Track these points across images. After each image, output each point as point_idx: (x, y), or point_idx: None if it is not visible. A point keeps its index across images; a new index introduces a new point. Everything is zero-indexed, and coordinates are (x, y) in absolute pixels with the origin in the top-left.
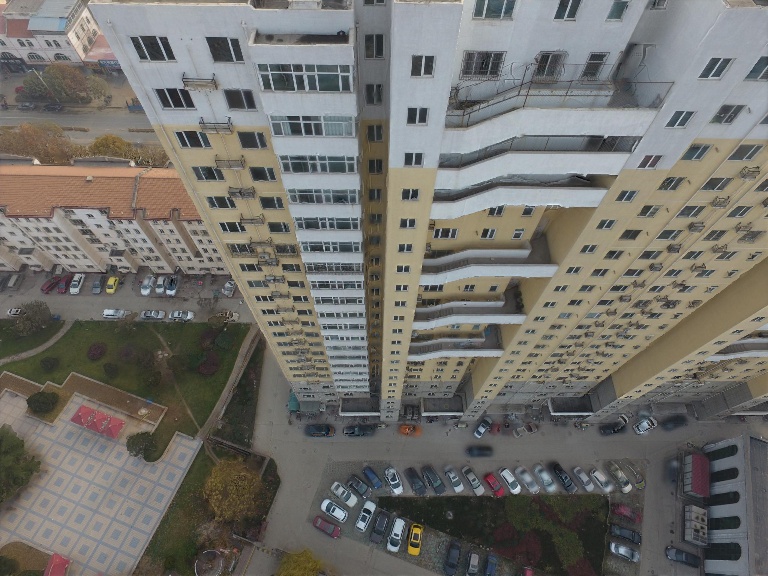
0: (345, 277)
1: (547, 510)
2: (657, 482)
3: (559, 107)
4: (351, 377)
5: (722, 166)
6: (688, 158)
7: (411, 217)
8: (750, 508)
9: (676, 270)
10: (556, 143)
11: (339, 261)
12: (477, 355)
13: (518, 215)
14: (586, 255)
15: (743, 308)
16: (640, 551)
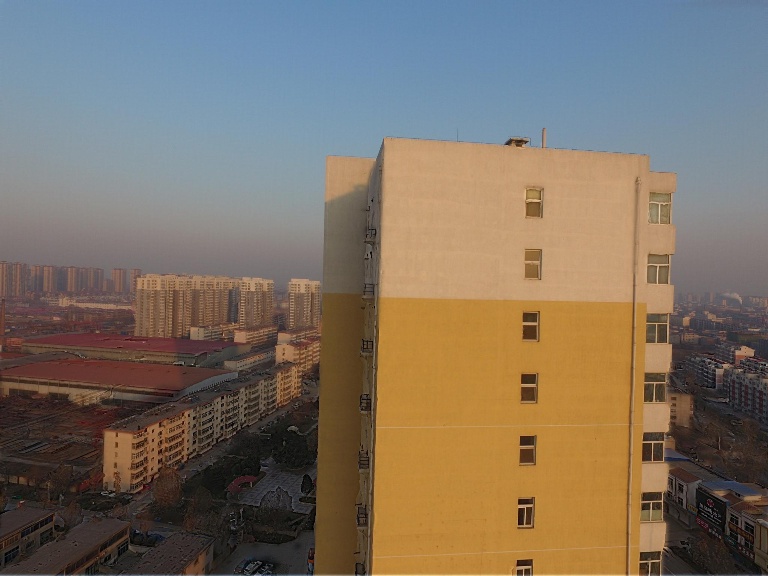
0: None
1: None
2: None
3: None
4: None
5: None
6: None
7: None
8: None
9: None
10: None
11: None
12: None
13: None
14: None
15: None
16: None
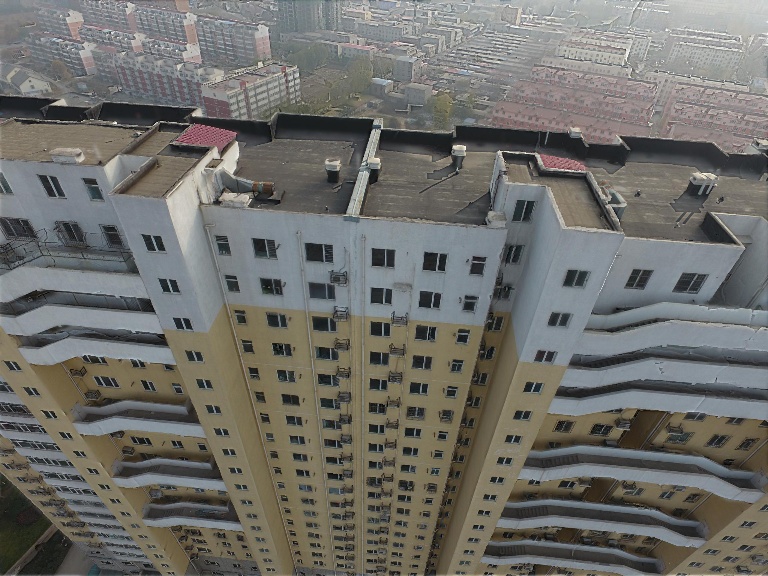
0: (22, 419)
1: None
2: None
3: (60, 267)
4: (119, 542)
5: (315, 336)
6: (275, 325)
7: (12, 360)
8: None
9: (376, 444)
10: (84, 299)
11: (3, 401)
12: (217, 527)
13: (160, 369)
14: (216, 416)
15: (467, 497)
16: None
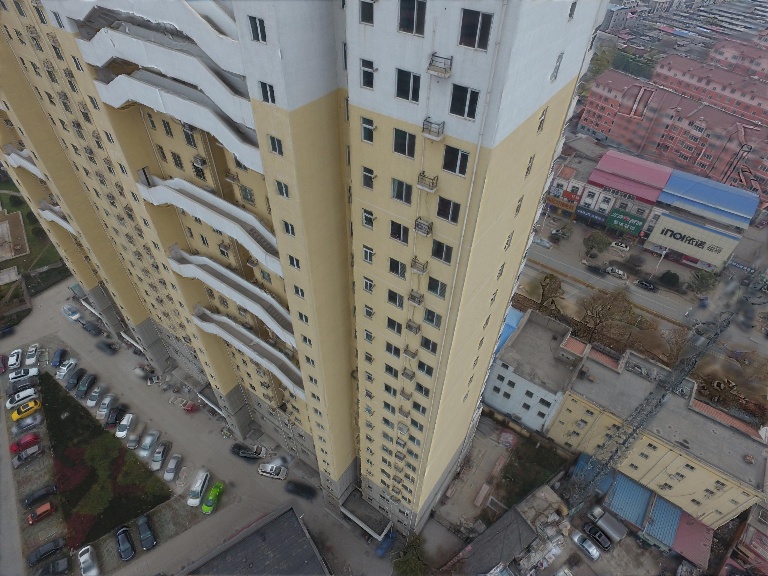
0: None
1: (119, 464)
2: (225, 521)
3: None
4: None
5: None
6: (6, 9)
7: None
8: (207, 556)
9: None
10: None
11: None
12: None
13: None
14: None
15: None
16: (140, 556)
